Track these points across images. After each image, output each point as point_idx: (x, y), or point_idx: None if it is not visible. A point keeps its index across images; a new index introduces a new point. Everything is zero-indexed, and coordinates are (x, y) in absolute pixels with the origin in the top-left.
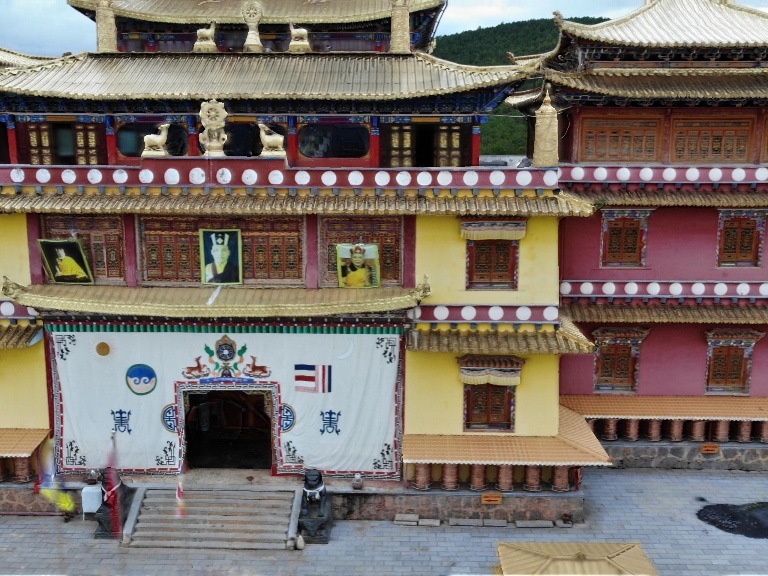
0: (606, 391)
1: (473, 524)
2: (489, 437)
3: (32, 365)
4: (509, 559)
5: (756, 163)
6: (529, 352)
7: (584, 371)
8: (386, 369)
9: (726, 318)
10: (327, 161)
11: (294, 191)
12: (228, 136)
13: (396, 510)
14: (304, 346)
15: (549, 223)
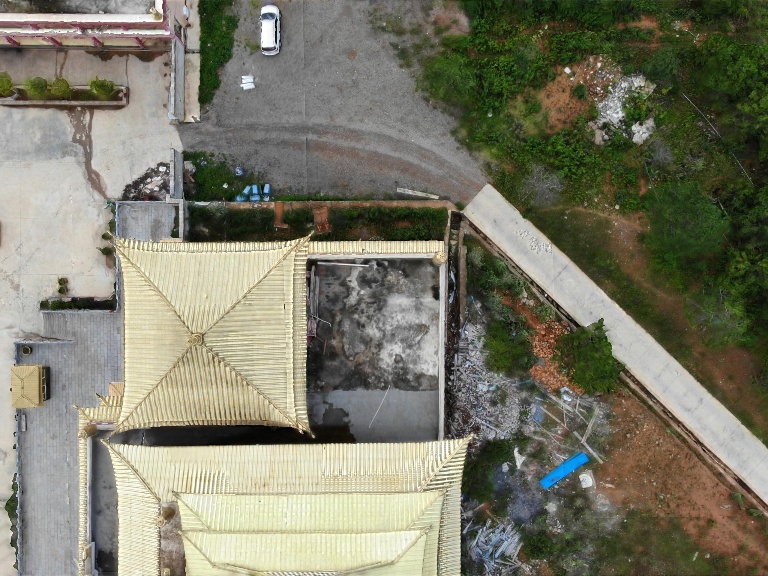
0: None
1: None
2: None
3: None
4: None
5: None
6: None
7: None
8: None
9: None
10: None
11: None
12: None
13: None
14: None
15: None
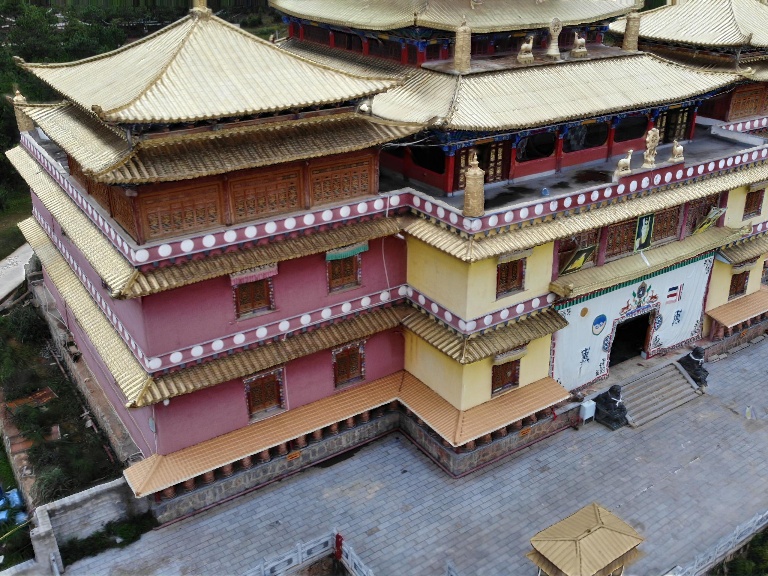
0: None
1: (738, 350)
2: (738, 300)
3: (545, 337)
4: None
5: None
6: None
7: None
8: (705, 277)
9: None
10: (626, 143)
11: None
12: None
13: (708, 355)
14: (675, 276)
15: None
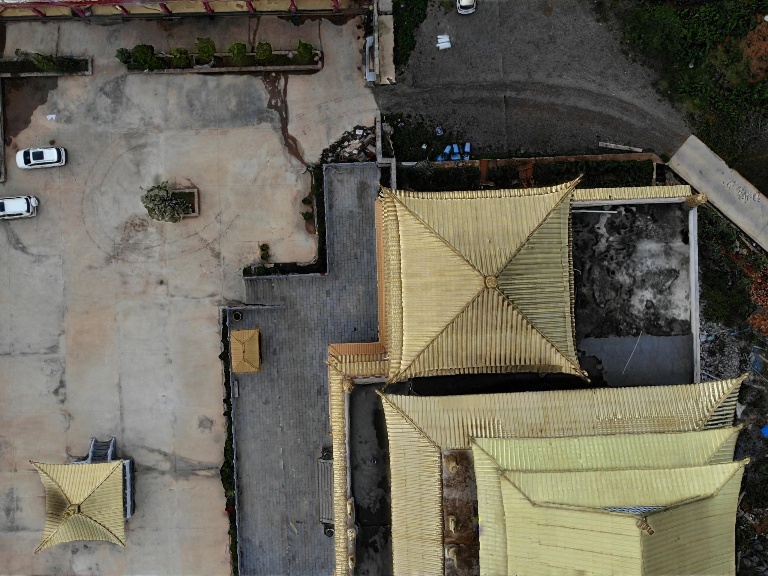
0: None
1: None
2: None
3: None
4: None
5: None
6: None
7: None
8: None
9: None
10: None
11: None
12: None
13: None
14: None
15: None
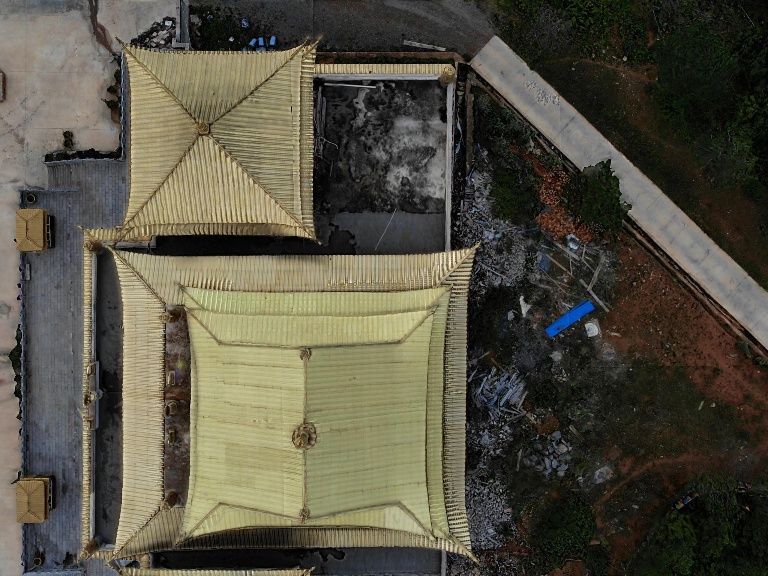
0: None
1: None
2: None
3: None
4: (33, 483)
5: None
6: None
7: None
8: None
9: None
10: None
11: None
12: None
13: None
14: None
15: None
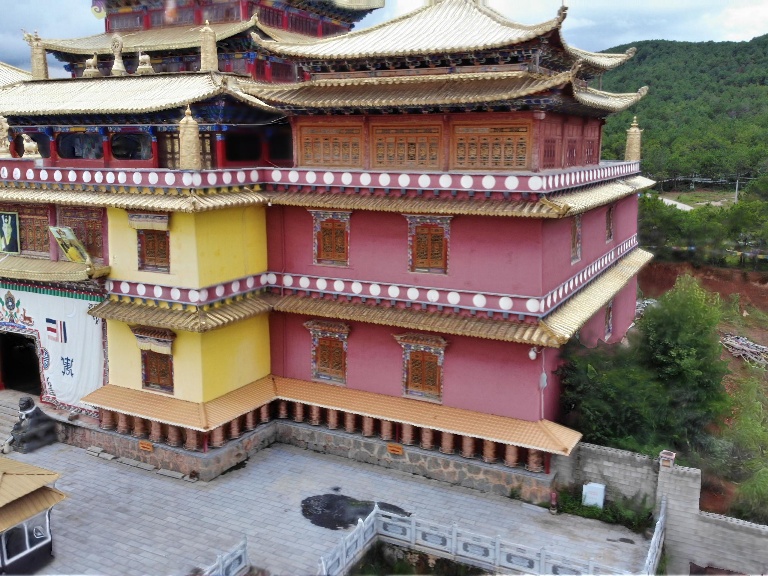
0: (323, 380)
1: (132, 464)
2: (156, 396)
3: None
4: None
5: (445, 170)
6: (159, 325)
7: (305, 359)
8: (95, 329)
9: (398, 321)
10: (128, 162)
11: (38, 185)
12: (114, 142)
13: (92, 442)
14: (49, 304)
15: (186, 218)
